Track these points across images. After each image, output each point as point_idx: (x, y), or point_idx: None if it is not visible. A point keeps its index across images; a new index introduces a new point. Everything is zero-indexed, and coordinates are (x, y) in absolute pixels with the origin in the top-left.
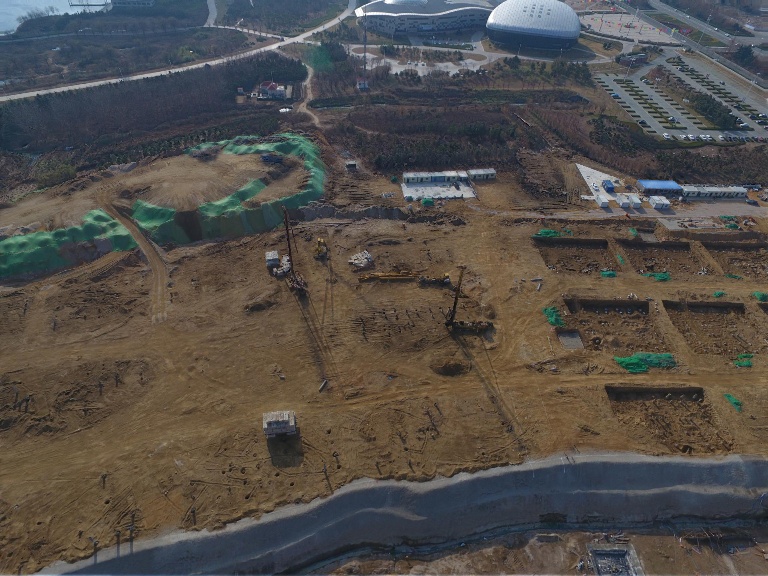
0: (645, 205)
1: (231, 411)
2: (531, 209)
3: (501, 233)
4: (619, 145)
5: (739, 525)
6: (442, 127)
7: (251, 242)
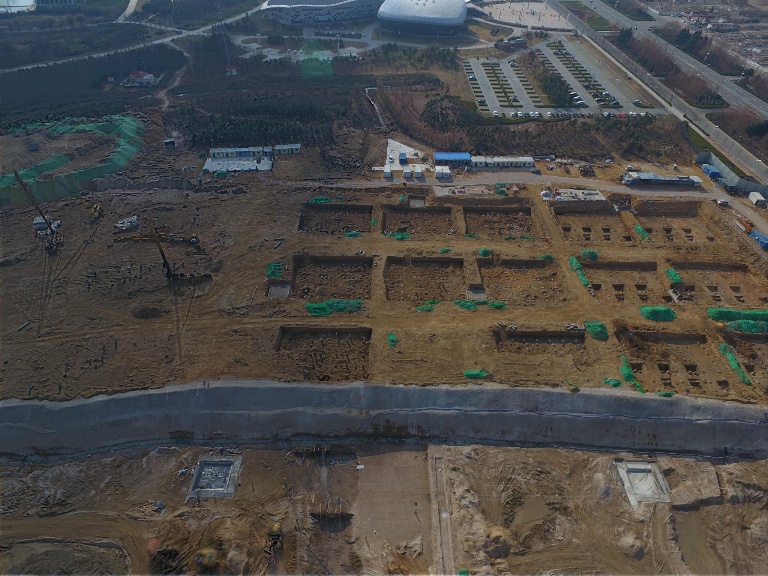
0: (429, 175)
1: None
2: (316, 179)
3: (275, 200)
4: (443, 122)
5: (351, 442)
6: (272, 108)
7: (35, 210)
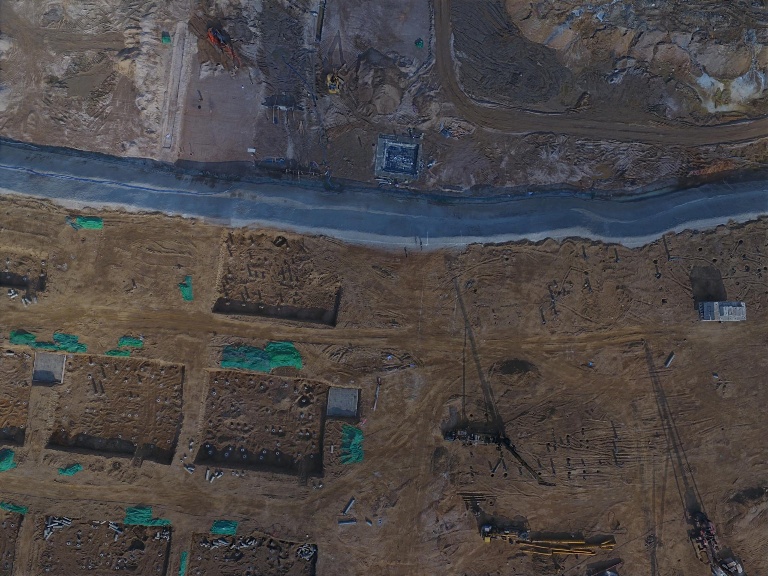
0: None
1: (767, 337)
2: None
3: None
4: None
5: (260, 178)
6: None
7: None
